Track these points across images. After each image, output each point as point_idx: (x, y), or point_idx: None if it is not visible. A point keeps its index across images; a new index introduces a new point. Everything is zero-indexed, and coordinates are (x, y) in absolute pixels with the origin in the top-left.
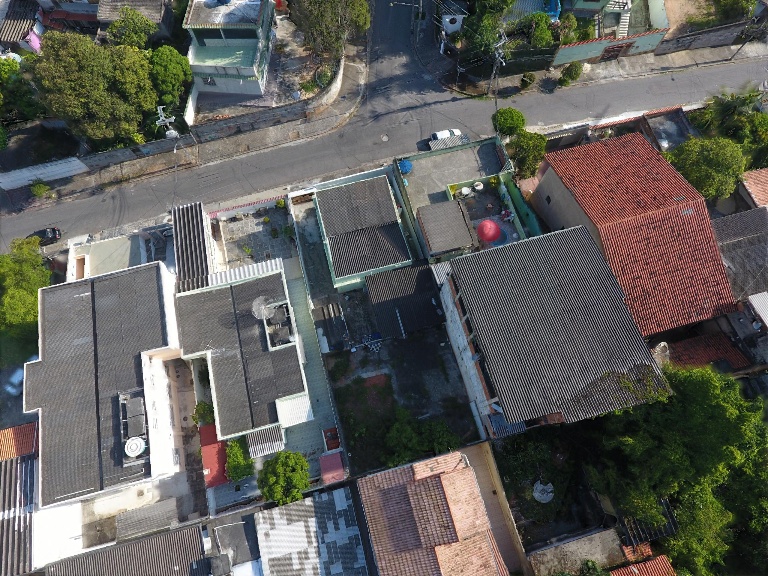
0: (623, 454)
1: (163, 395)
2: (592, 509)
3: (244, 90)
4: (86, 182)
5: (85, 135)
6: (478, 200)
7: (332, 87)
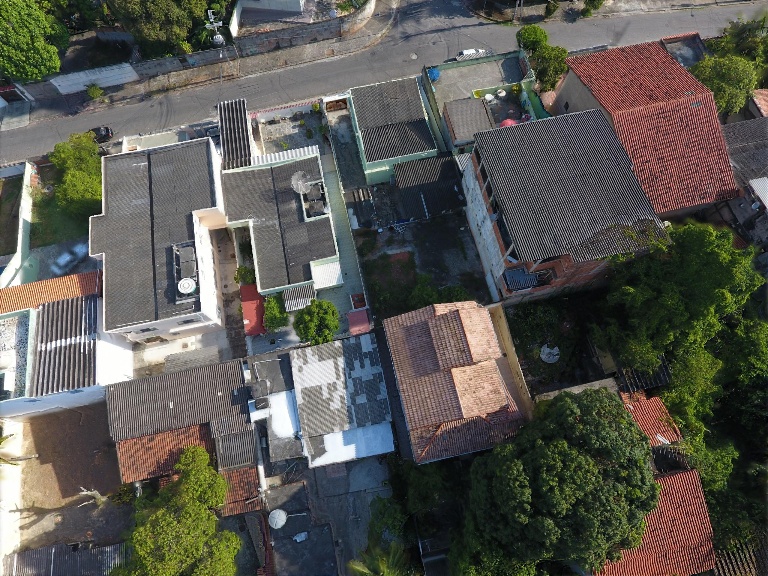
0: (625, 314)
1: (209, 257)
2: (594, 371)
3: (285, 6)
4: (136, 90)
5: (137, 44)
6: (500, 107)
7: (366, 7)
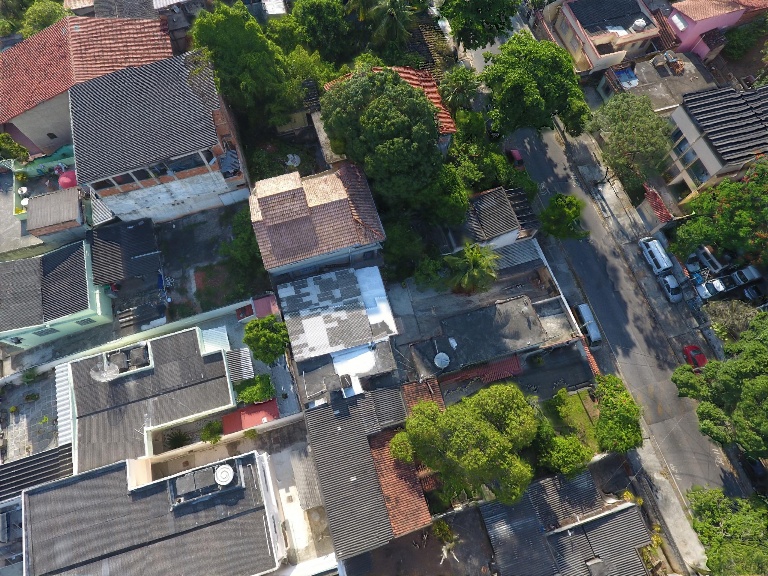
0: (261, 100)
1: None
2: (306, 133)
3: None
4: None
5: None
6: None
7: None
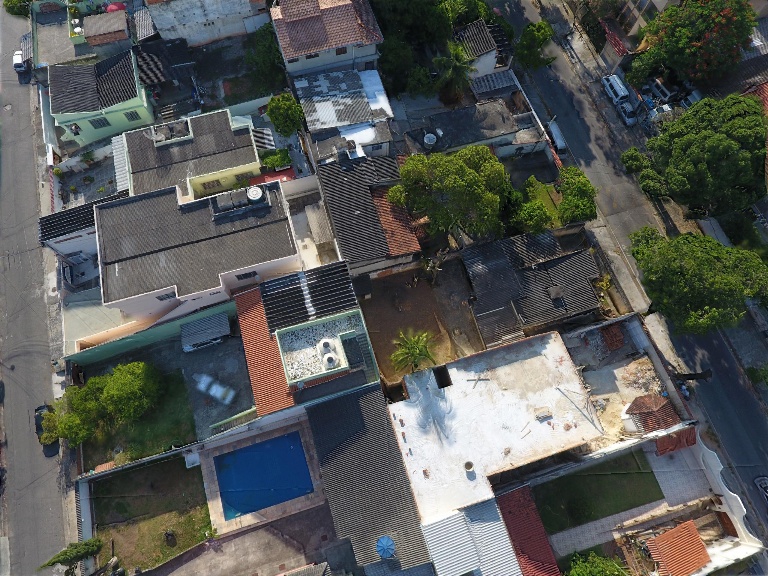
0: None
1: None
2: None
3: None
4: None
5: None
6: None
7: None
